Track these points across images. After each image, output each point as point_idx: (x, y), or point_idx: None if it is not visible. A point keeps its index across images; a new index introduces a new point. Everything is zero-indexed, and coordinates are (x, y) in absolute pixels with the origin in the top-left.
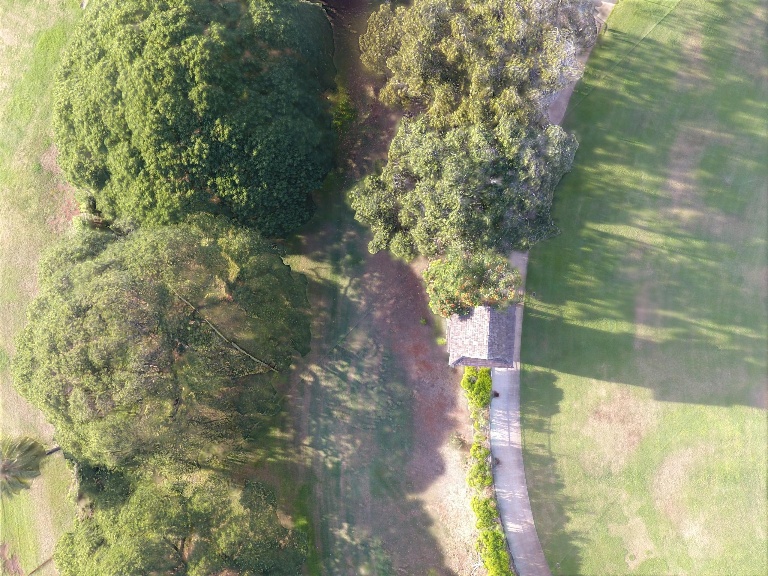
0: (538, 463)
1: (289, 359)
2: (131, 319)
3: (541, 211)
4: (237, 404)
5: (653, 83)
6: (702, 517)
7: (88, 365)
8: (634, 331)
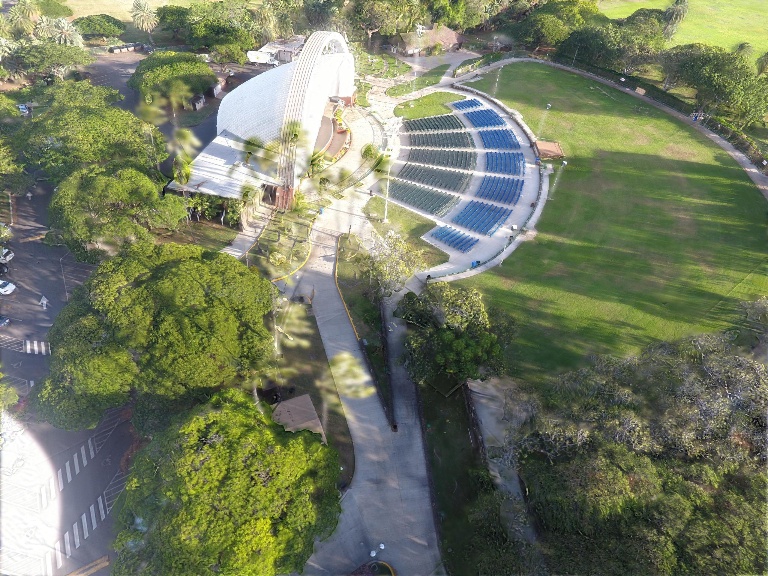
0: None
1: None
2: None
3: None
4: None
5: (728, 254)
6: None
7: None
8: None
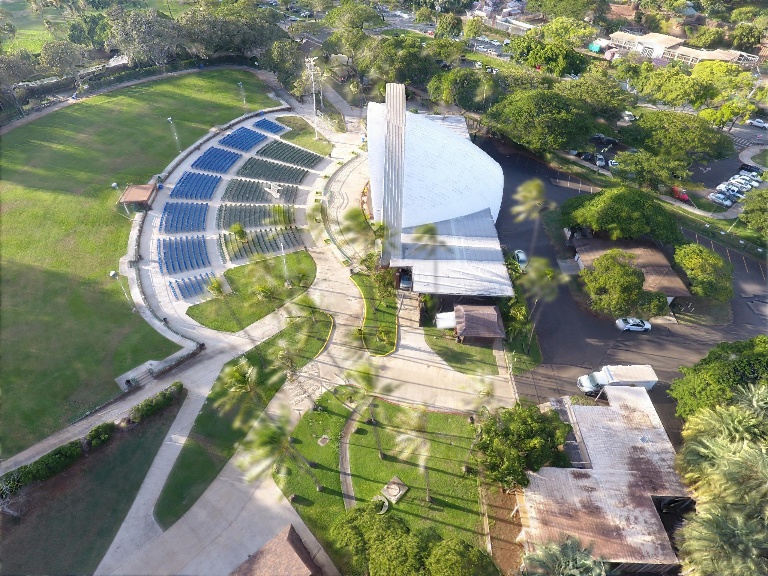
0: None
1: None
2: None
3: None
4: None
5: (92, 113)
6: None
7: None
8: None
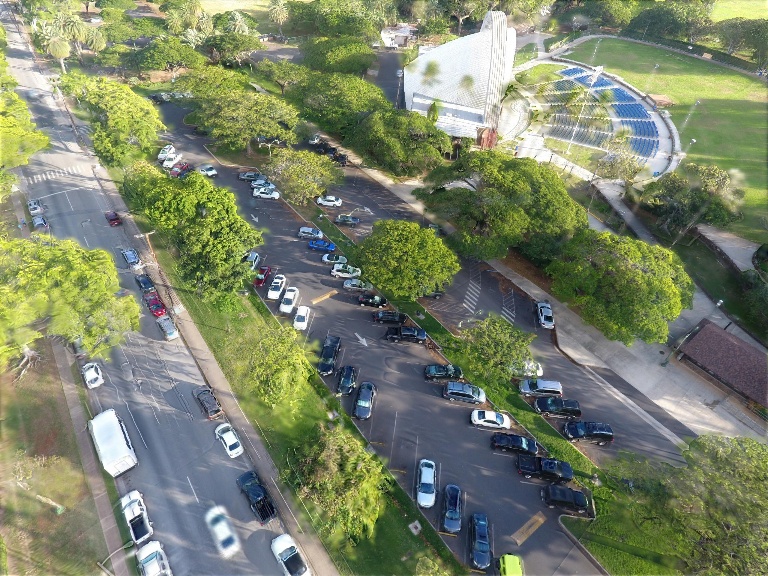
0: None
1: None
2: None
3: None
4: None
5: None
6: None
7: None
8: None
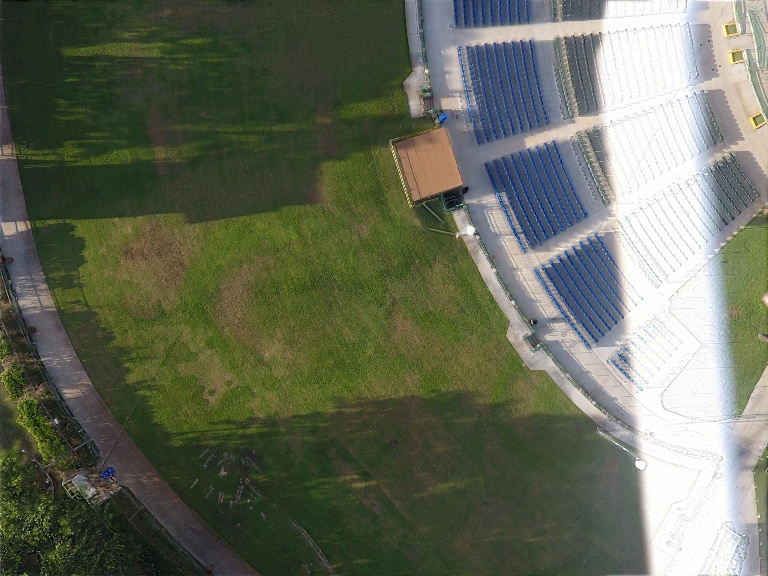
0: (79, 321)
1: None
2: None
3: None
4: None
5: None
6: (279, 333)
7: None
8: (152, 156)
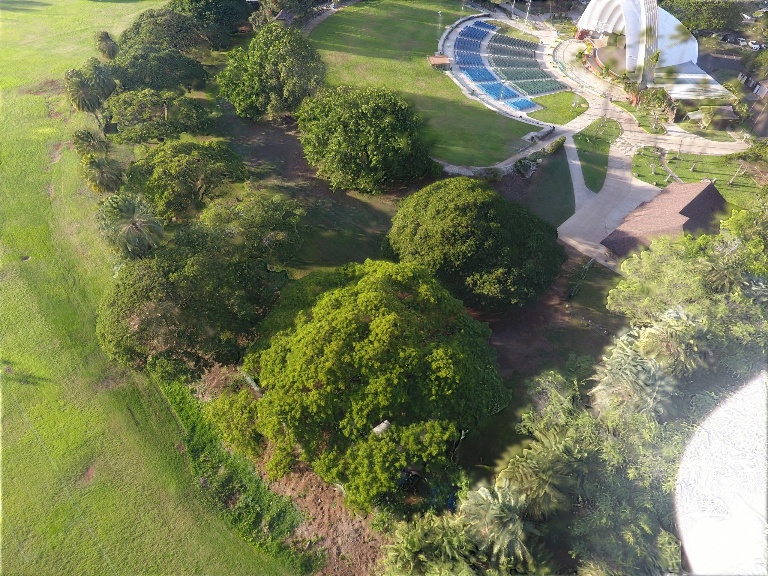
0: None
1: (218, 46)
2: (170, 10)
3: (302, 1)
4: (196, 41)
5: None
6: None
7: (152, 17)
8: None
